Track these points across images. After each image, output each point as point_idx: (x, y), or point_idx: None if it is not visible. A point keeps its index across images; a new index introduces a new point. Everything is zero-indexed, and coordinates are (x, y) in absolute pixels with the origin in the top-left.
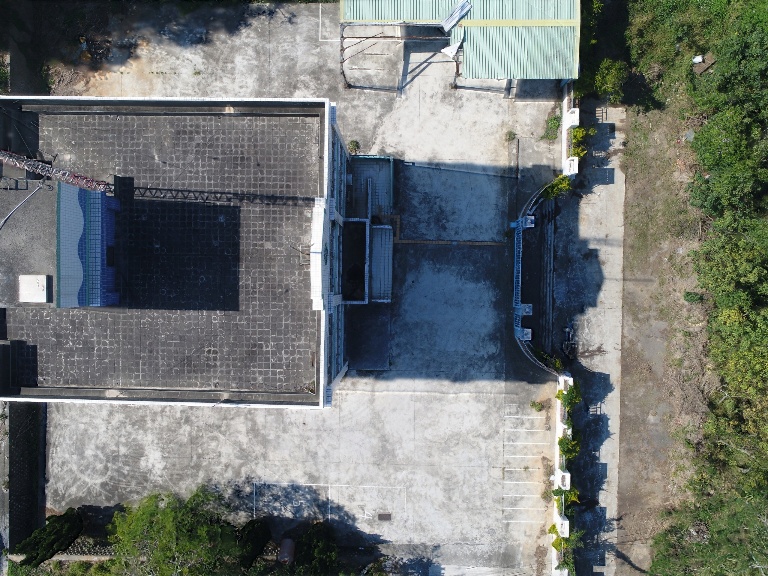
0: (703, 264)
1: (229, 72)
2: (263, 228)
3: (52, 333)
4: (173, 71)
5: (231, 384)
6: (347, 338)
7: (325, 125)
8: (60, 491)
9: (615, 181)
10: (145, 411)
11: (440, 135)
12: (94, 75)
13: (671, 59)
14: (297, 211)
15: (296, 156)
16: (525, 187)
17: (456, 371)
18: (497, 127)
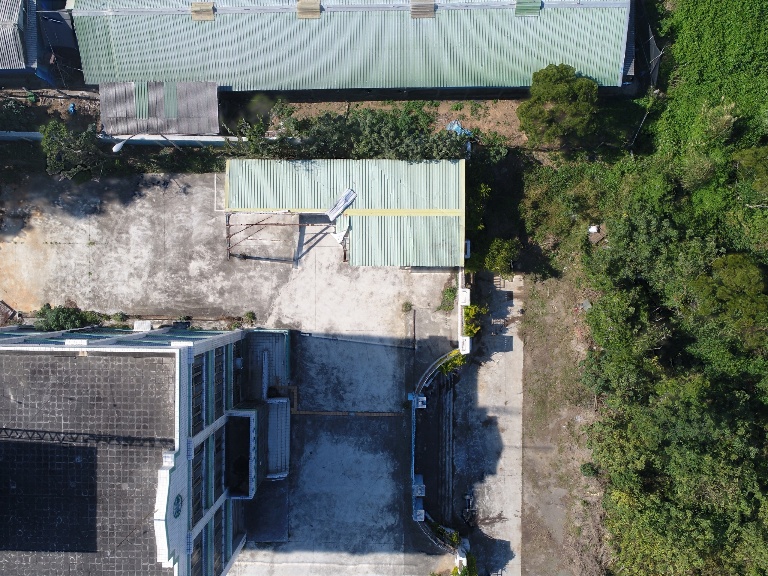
0: (595, 444)
1: (124, 242)
2: (120, 469)
3: None
4: (67, 241)
5: None
6: (245, 511)
7: (176, 376)
8: None
9: (513, 348)
10: None
11: (337, 306)
12: None
13: (566, 230)
14: (154, 452)
15: (153, 397)
16: (422, 358)
17: (355, 542)
18: (393, 298)
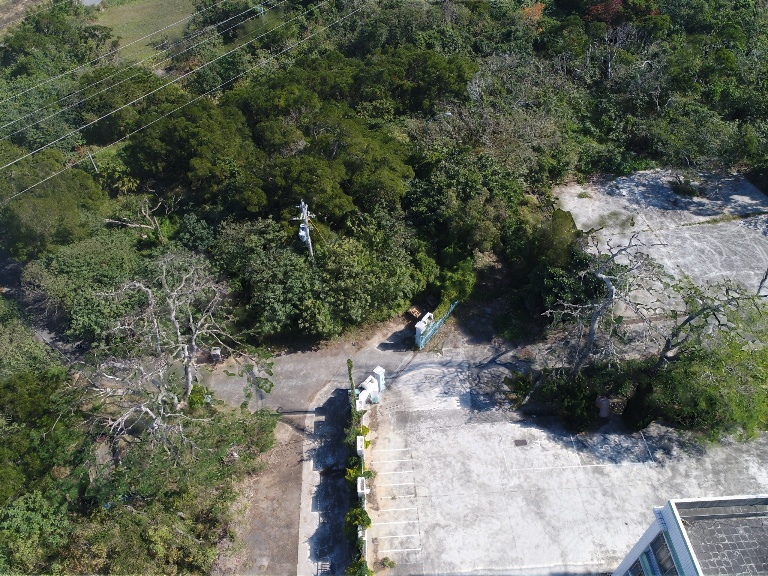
0: None
1: None
2: None
3: None
4: None
5: None
6: None
7: None
8: None
9: None
10: None
11: None
12: None
13: None
14: None
15: None
16: None
17: None
18: None
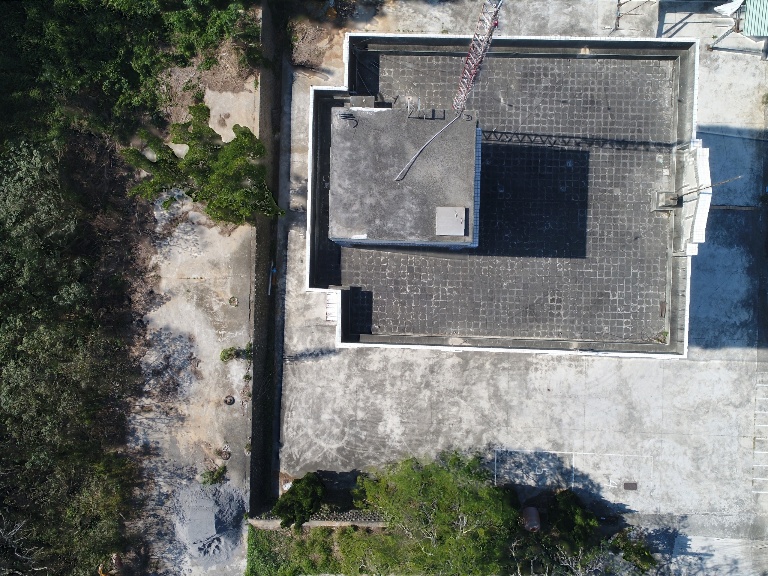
0: None
1: None
2: (613, 174)
3: (389, 279)
4: (420, 29)
5: (575, 334)
6: None
7: (695, 66)
8: (295, 456)
9: None
10: (384, 375)
11: None
12: (338, 32)
13: None
14: (649, 157)
15: (648, 100)
16: None
17: (707, 338)
18: (753, 89)
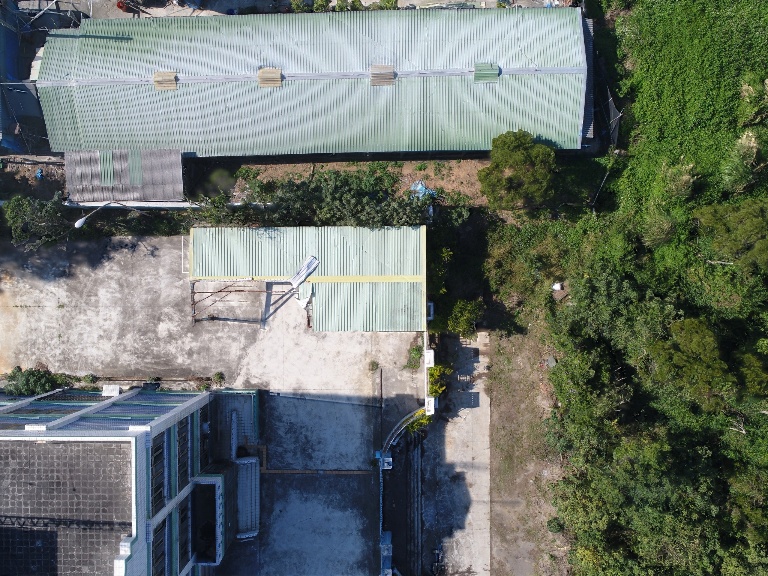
0: (559, 502)
1: (93, 305)
2: (80, 552)
3: None
4: (37, 304)
5: None
6: (216, 569)
7: (132, 464)
8: None
9: (480, 404)
10: None
11: (304, 365)
12: None
13: (530, 288)
14: (114, 535)
15: (111, 481)
16: (389, 416)
17: None
18: (360, 357)
